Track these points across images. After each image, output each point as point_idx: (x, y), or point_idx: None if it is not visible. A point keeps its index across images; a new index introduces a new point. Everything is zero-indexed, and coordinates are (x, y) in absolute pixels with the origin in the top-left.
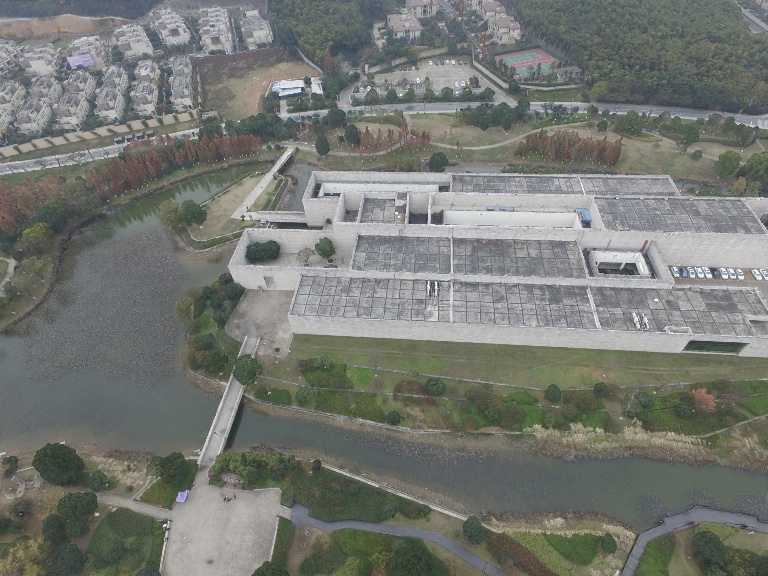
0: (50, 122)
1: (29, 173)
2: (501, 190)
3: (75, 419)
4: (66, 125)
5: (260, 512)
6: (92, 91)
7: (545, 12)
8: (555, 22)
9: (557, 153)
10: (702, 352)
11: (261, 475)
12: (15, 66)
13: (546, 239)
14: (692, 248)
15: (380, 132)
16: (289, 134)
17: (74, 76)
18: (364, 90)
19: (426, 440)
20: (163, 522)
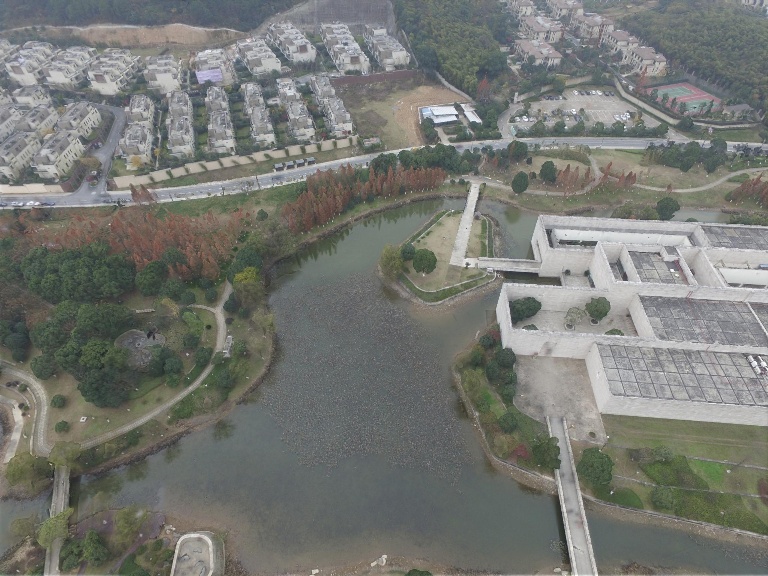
0: (197, 144)
1: (193, 202)
2: (764, 245)
3: (383, 523)
4: (221, 148)
5: None
6: (228, 109)
7: (690, 45)
8: (705, 56)
9: None
10: None
11: None
12: (132, 78)
13: None
14: None
15: (577, 170)
16: (469, 167)
17: (213, 93)
18: (520, 120)
19: None
20: None
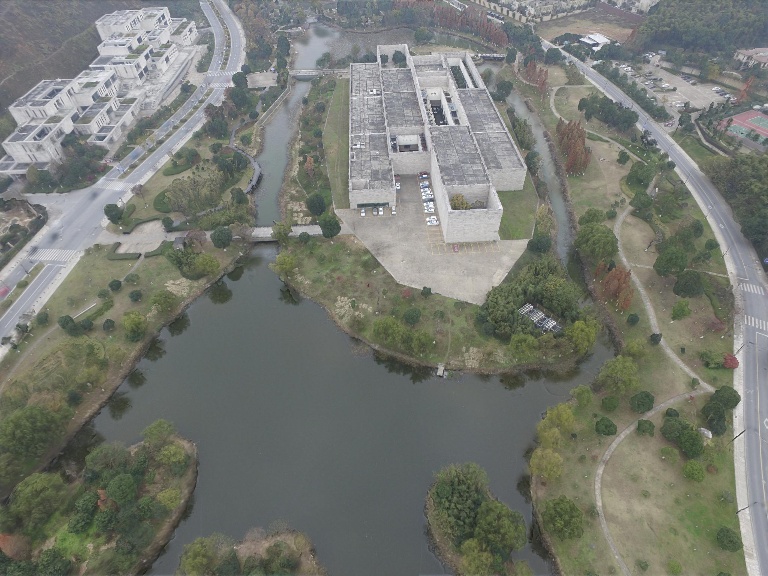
0: None
1: None
2: (474, 105)
3: None
4: None
5: (268, 84)
6: None
7: None
8: None
9: None
10: None
11: None
12: None
13: None
14: None
15: None
16: None
17: None
18: (624, 67)
19: None
20: None
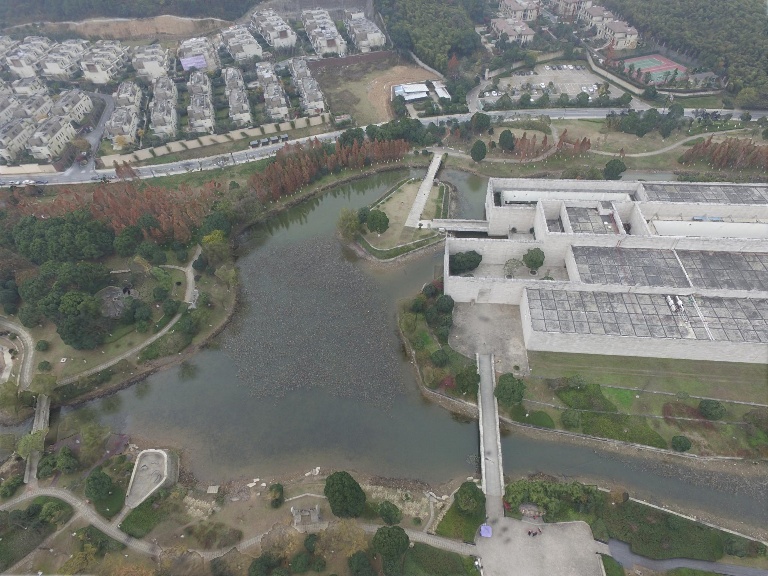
0: (179, 125)
1: (172, 177)
2: (701, 199)
3: (320, 442)
4: (200, 128)
5: (575, 548)
6: (210, 93)
7: (662, 17)
8: (676, 27)
9: (727, 161)
10: None
11: (561, 507)
12: (123, 67)
13: None
14: None
15: (535, 138)
16: (433, 139)
17: (195, 78)
18: (489, 95)
19: (718, 468)
20: (472, 559)
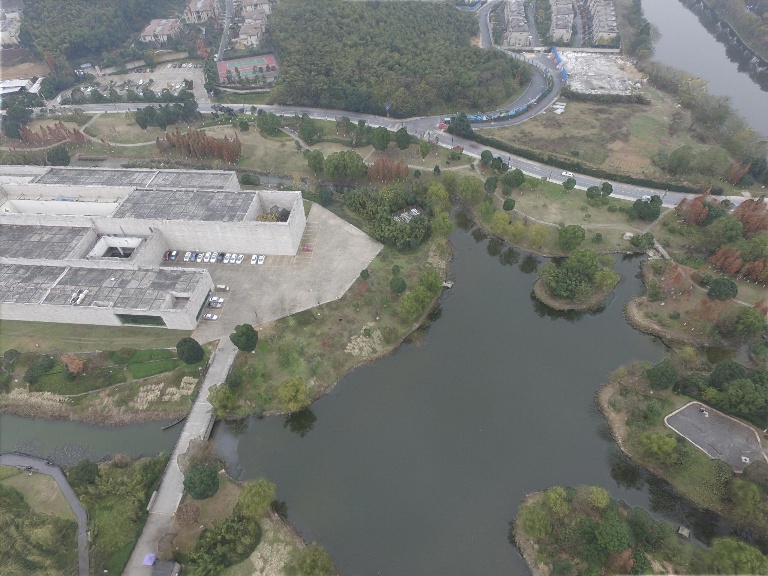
0: None
1: None
2: (79, 182)
3: None
4: None
5: None
6: None
7: (282, 20)
8: (284, 30)
9: (190, 150)
10: (140, 325)
11: None
12: None
13: (69, 225)
14: (193, 235)
15: (43, 129)
16: None
17: None
18: (85, 90)
19: None
20: None
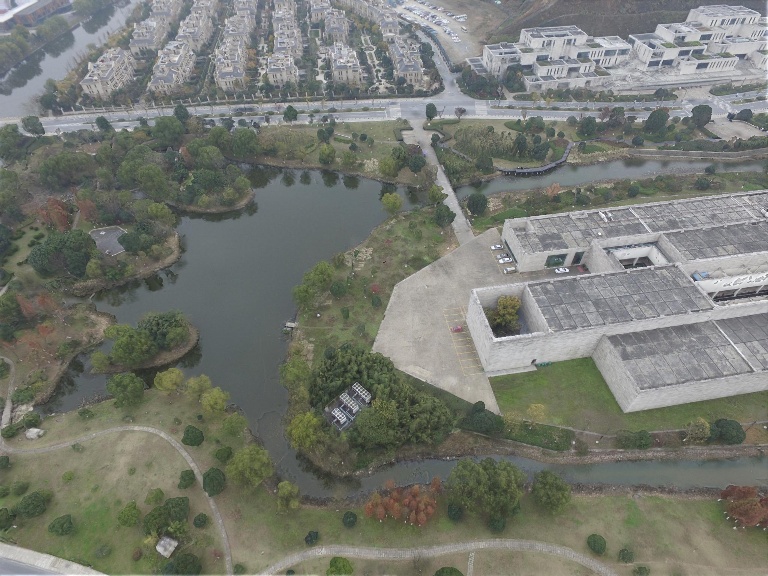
0: None
1: None
2: None
3: None
4: None
5: None
6: None
7: None
8: None
9: None
10: None
11: None
12: None
13: None
14: None
15: None
16: None
17: None
18: None
19: (683, 174)
20: None
